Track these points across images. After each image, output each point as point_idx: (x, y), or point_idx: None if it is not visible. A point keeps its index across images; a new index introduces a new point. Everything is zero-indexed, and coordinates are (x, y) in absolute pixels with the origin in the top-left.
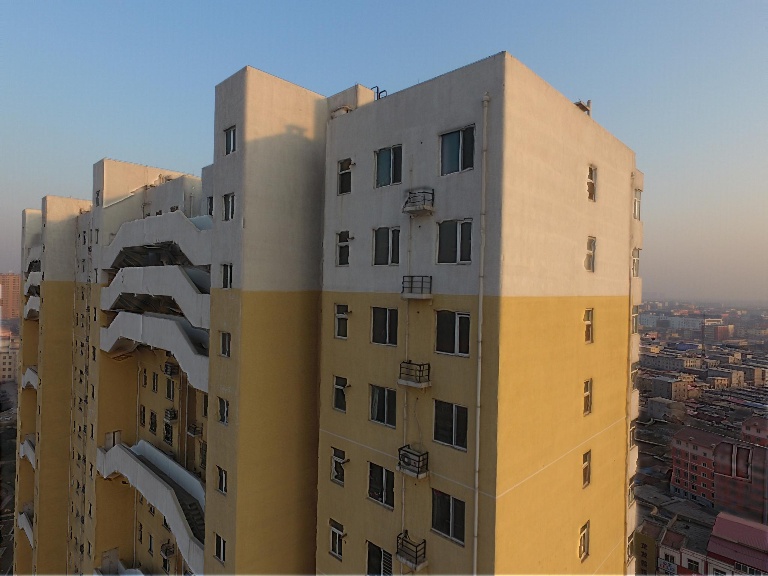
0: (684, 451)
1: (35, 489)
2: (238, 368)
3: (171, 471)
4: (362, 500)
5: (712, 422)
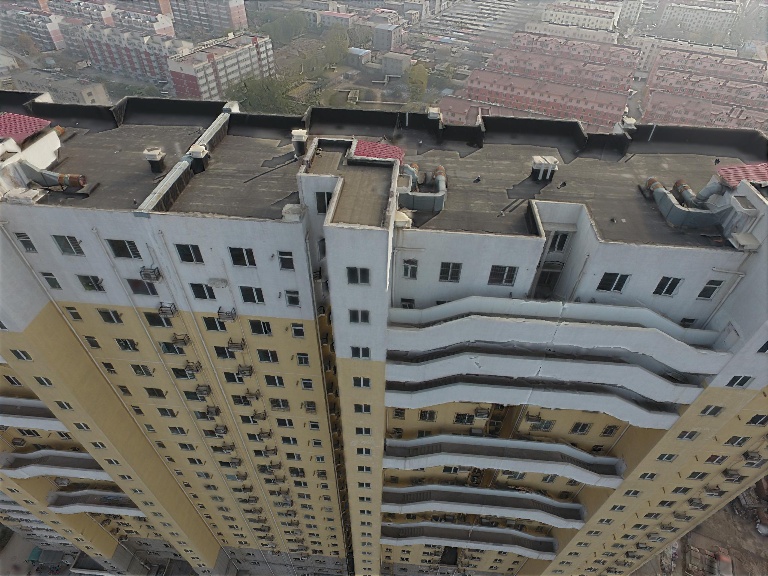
0: (445, 119)
1: (129, 491)
2: (727, 421)
3: (511, 445)
4: (741, 426)
5: (429, 69)
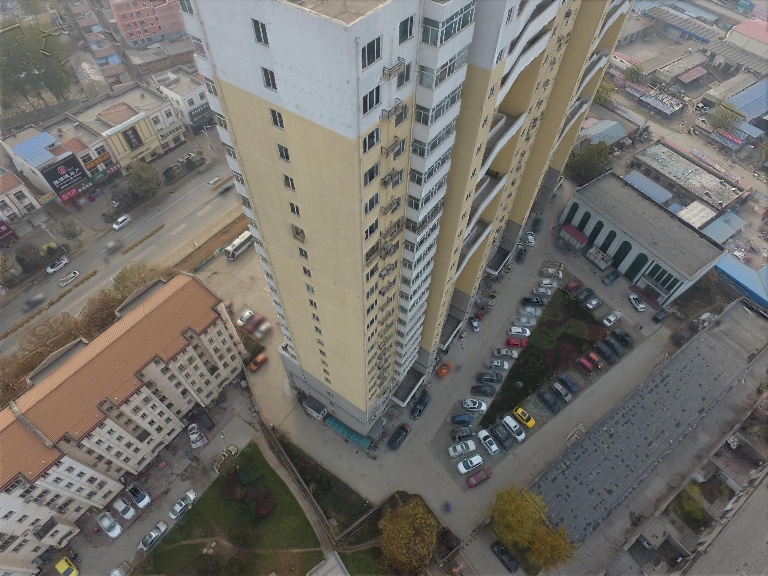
0: (125, 3)
1: None
2: None
3: None
4: None
5: None
